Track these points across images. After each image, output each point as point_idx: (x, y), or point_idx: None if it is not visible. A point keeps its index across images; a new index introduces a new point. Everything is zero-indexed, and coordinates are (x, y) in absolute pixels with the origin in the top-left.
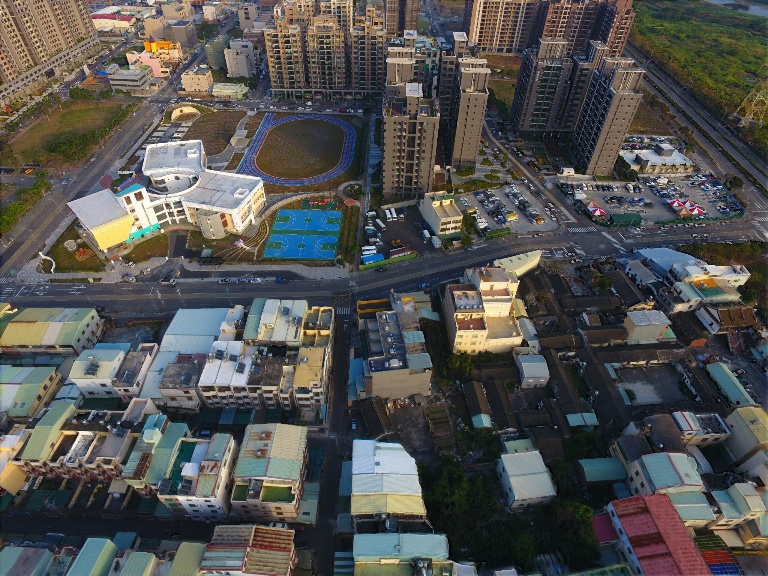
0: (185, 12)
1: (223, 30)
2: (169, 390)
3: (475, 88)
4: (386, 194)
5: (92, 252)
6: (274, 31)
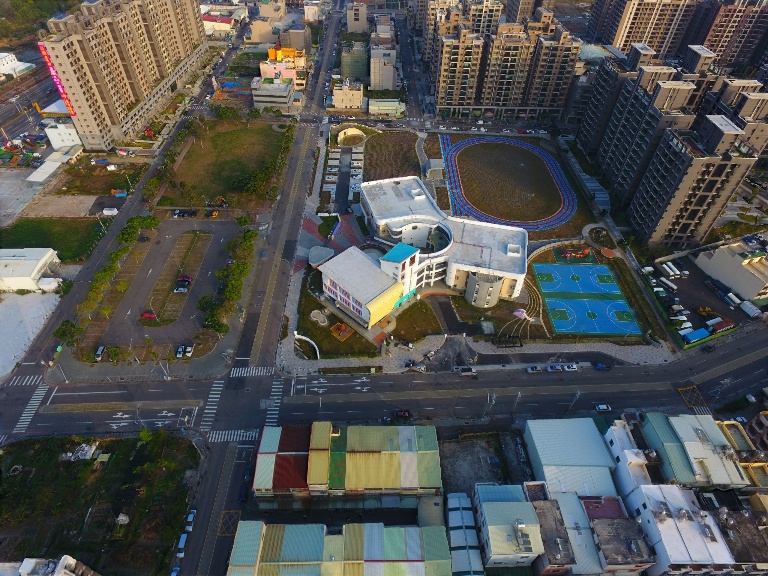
0: (281, 12)
1: (329, 33)
2: (619, 565)
3: (755, 116)
4: (652, 243)
5: (349, 328)
6: (455, 41)
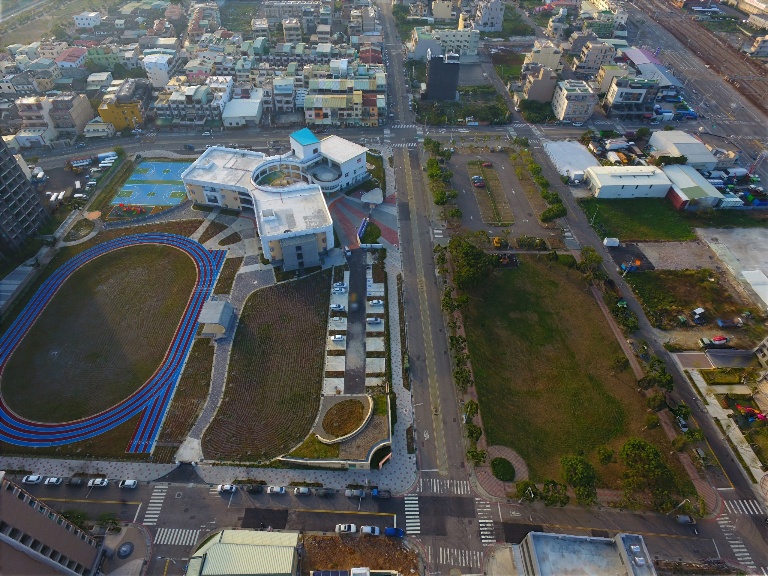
0: None
1: None
2: None
3: None
4: None
5: None
6: None
